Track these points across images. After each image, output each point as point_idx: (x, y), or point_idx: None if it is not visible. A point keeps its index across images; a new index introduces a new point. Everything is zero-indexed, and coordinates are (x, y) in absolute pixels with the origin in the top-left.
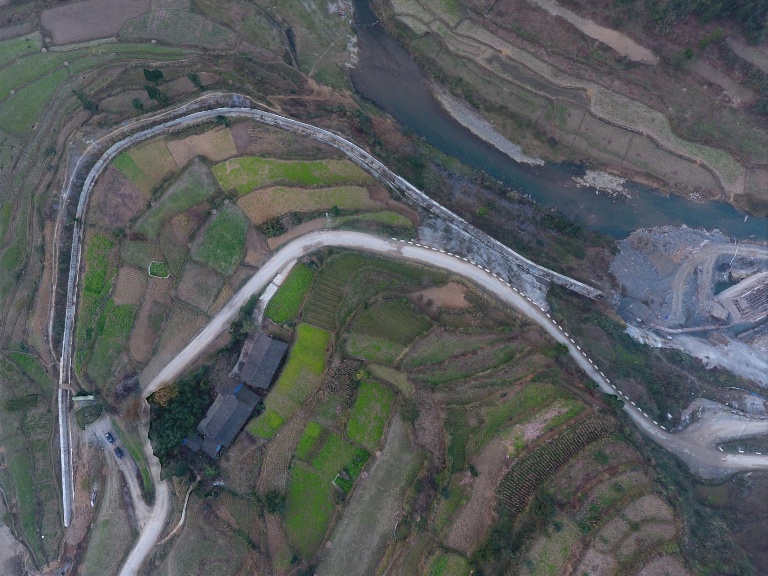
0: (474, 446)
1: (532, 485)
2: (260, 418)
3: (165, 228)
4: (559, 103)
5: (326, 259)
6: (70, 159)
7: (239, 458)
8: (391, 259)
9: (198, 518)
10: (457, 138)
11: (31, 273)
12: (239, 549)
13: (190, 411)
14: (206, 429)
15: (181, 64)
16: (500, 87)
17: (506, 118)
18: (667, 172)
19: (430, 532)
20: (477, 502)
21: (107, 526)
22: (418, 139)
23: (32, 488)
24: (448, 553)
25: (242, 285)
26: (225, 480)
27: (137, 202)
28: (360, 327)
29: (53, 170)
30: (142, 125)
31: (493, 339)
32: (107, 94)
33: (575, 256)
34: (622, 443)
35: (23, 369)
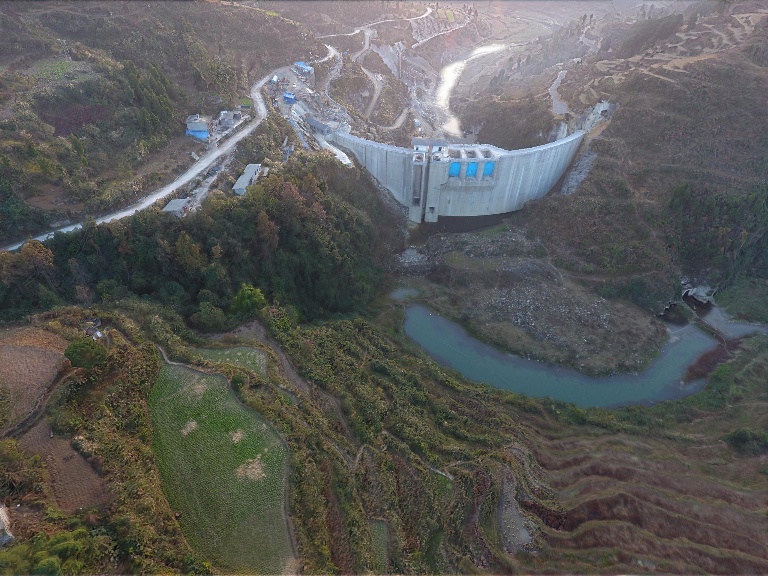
0: None
1: None
2: None
3: None
4: None
5: None
6: None
7: None
8: None
9: None
10: None
11: None
12: None
13: None
14: None
15: None
16: None
17: None
18: (465, 75)
19: None
20: None
21: None
22: None
23: None
24: None
25: None
26: None
27: None
28: None
29: None
30: None
31: None
32: None
33: None
34: None
35: None
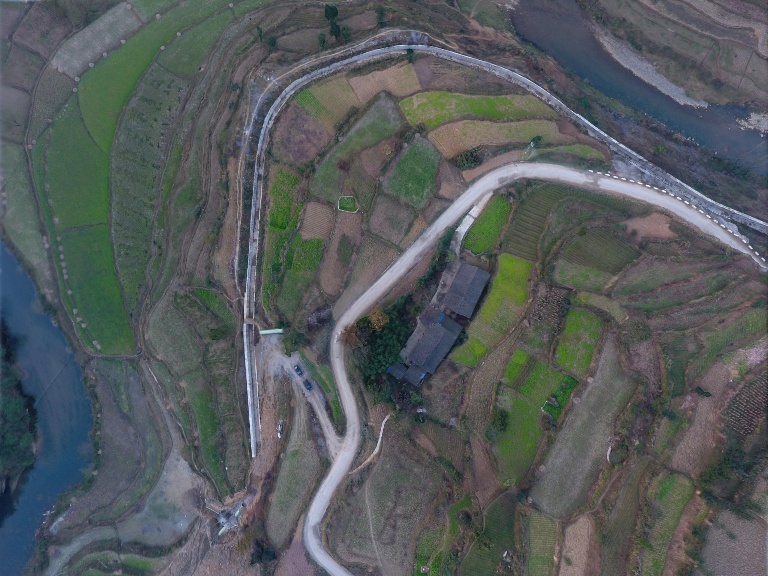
0: (695, 371)
1: (761, 407)
2: (463, 347)
3: (354, 162)
4: (725, 44)
5: (526, 190)
6: (251, 96)
7: (441, 386)
8: (590, 190)
9: (394, 447)
10: (619, 80)
11: (210, 211)
12: (434, 478)
13: (397, 338)
14: (412, 357)
15: (351, 3)
16: (665, 28)
17: (669, 60)
18: None
19: (651, 455)
20: (700, 425)
21: (296, 456)
22: (580, 81)
23: (215, 421)
24: (674, 474)
25: (436, 218)
26: (427, 408)
27: (321, 138)
28: (568, 255)
29: (233, 108)
30: (321, 62)
31: (704, 268)
32: (281, 33)
33: (749, 197)
34: None
35: (206, 304)
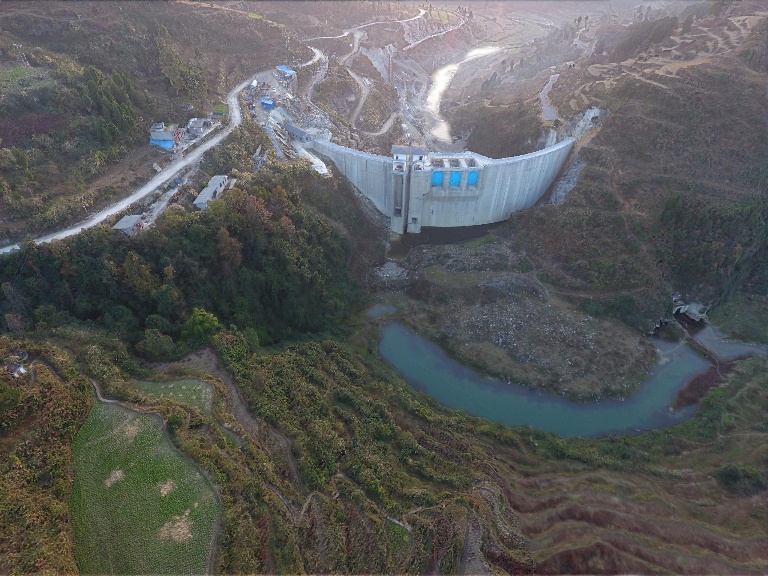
0: None
1: None
2: None
3: None
4: None
5: None
6: None
7: None
8: None
9: None
10: None
11: None
12: None
13: None
14: None
15: None
16: None
17: None
18: (458, 78)
19: None
20: None
21: None
22: None
23: None
24: None
25: None
26: None
27: None
28: None
29: None
30: None
31: None
32: None
33: None
34: (362, 1)
35: None
